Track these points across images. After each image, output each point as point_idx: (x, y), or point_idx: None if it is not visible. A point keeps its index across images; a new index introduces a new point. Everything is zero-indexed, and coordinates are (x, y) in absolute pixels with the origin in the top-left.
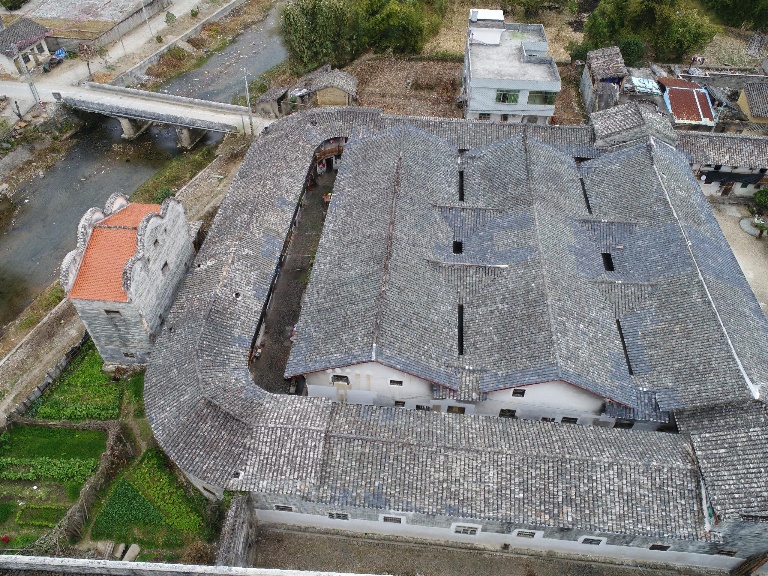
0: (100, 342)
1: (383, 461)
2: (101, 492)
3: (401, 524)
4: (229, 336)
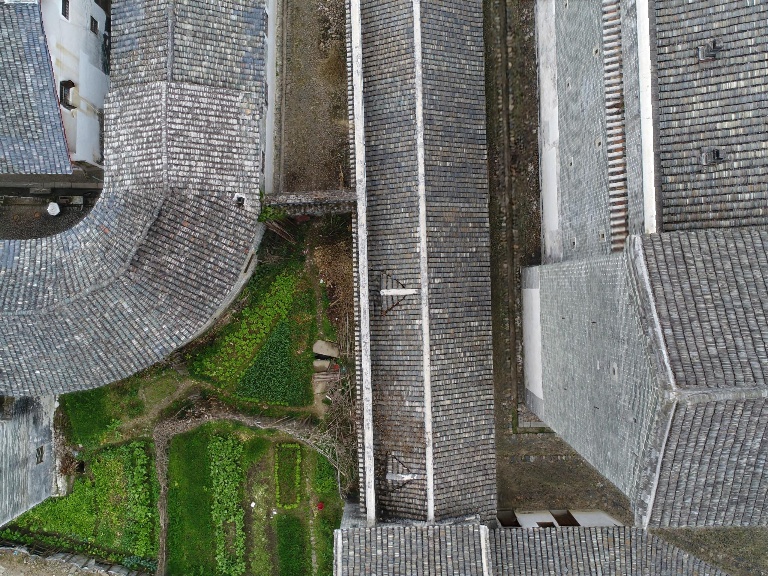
0: (22, 502)
1: (202, 5)
2: (254, 414)
3: (268, 18)
4: (1, 273)
